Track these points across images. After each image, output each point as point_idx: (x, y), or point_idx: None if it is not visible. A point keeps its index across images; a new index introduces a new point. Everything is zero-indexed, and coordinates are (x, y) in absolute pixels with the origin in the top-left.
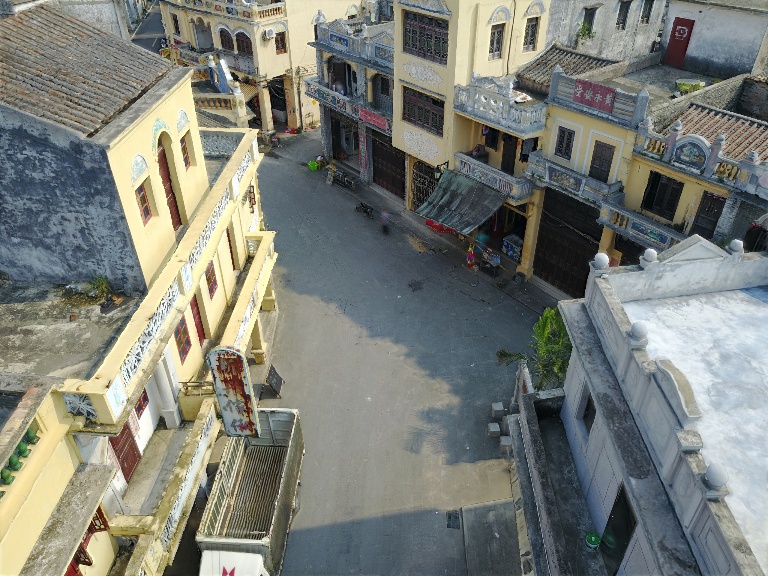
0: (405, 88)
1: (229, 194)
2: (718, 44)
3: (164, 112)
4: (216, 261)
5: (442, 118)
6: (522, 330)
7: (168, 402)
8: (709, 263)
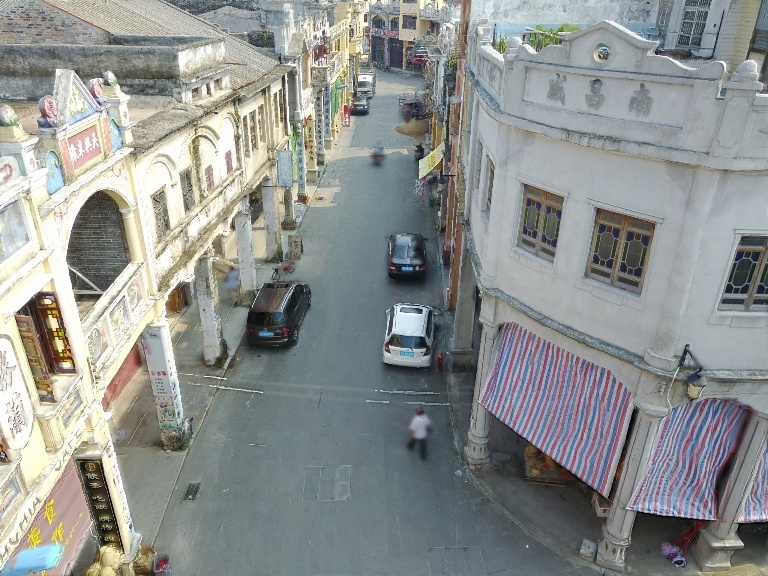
0: (403, 16)
1: (363, 7)
2: None
3: None
4: None
5: (416, 23)
6: None
7: None
8: None
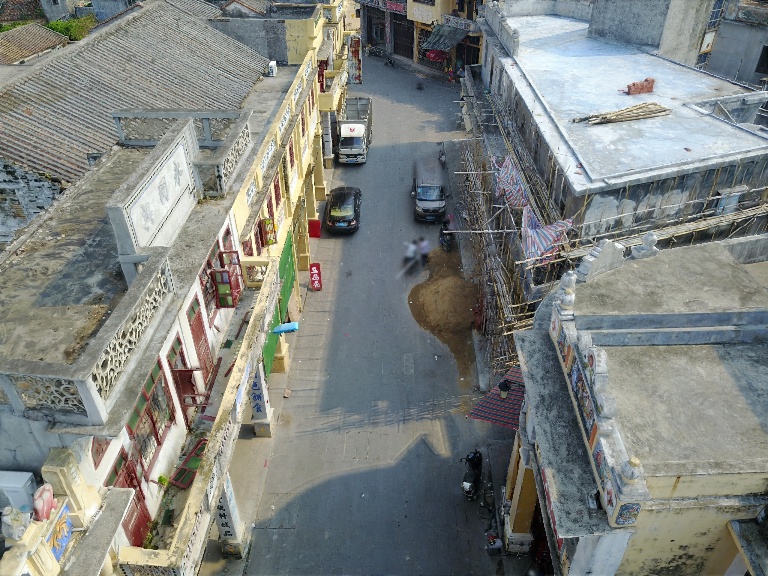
0: None
1: None
2: None
3: None
4: None
5: None
6: None
7: (331, 60)
8: (529, 1)
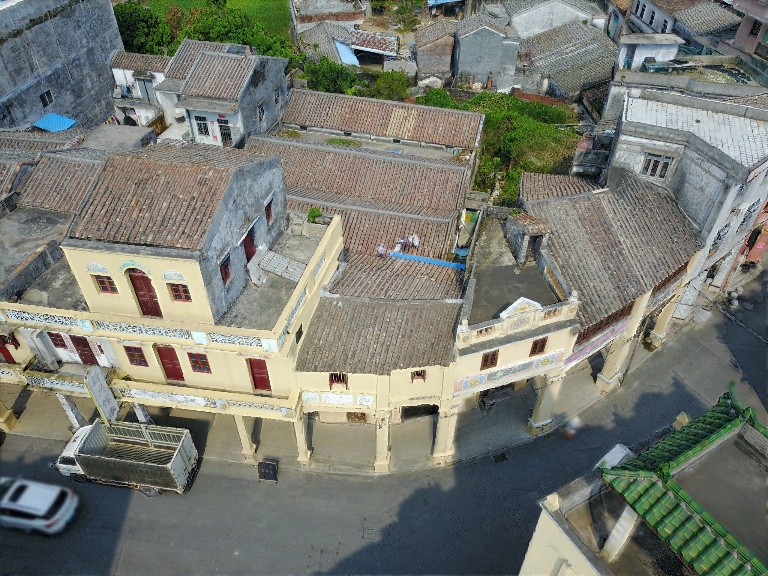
0: None
1: None
2: None
3: (145, 262)
4: (217, 363)
5: None
6: None
7: None
8: None
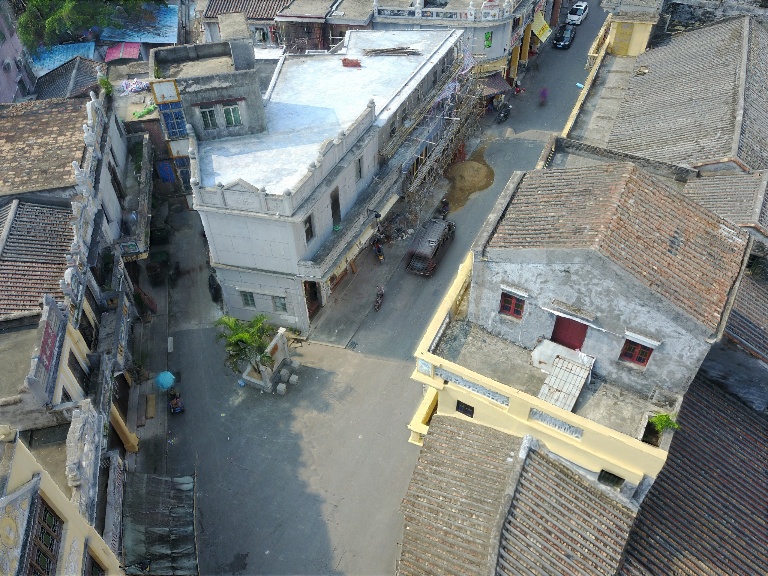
0: None
1: None
2: None
3: None
4: None
5: (92, 568)
6: None
7: None
8: None
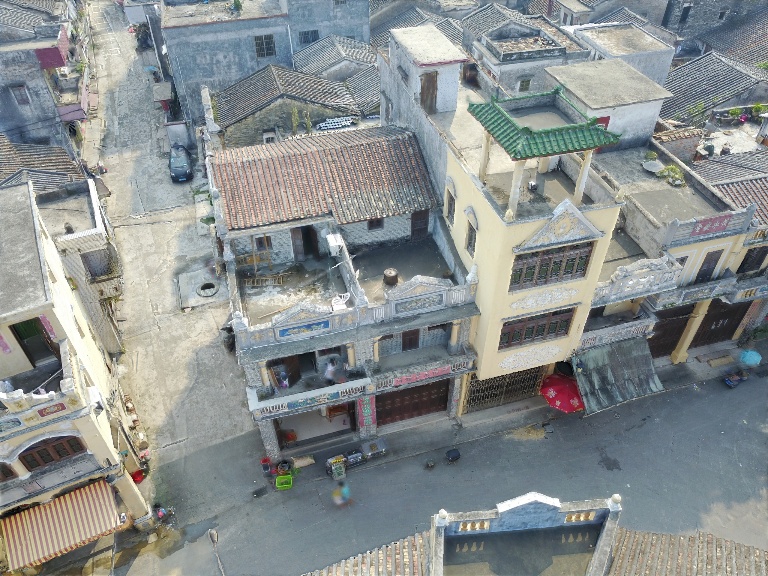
0: None
1: None
2: (628, 126)
3: None
4: None
5: (565, 321)
6: (692, 410)
7: None
8: None
